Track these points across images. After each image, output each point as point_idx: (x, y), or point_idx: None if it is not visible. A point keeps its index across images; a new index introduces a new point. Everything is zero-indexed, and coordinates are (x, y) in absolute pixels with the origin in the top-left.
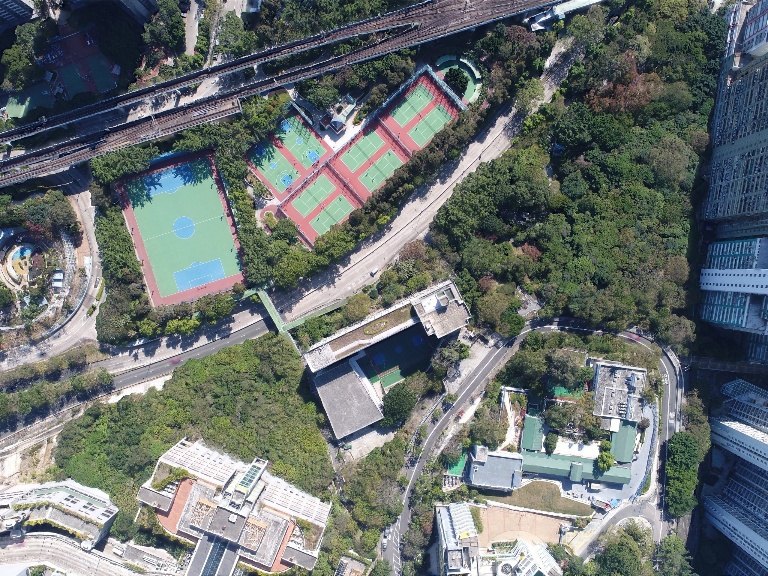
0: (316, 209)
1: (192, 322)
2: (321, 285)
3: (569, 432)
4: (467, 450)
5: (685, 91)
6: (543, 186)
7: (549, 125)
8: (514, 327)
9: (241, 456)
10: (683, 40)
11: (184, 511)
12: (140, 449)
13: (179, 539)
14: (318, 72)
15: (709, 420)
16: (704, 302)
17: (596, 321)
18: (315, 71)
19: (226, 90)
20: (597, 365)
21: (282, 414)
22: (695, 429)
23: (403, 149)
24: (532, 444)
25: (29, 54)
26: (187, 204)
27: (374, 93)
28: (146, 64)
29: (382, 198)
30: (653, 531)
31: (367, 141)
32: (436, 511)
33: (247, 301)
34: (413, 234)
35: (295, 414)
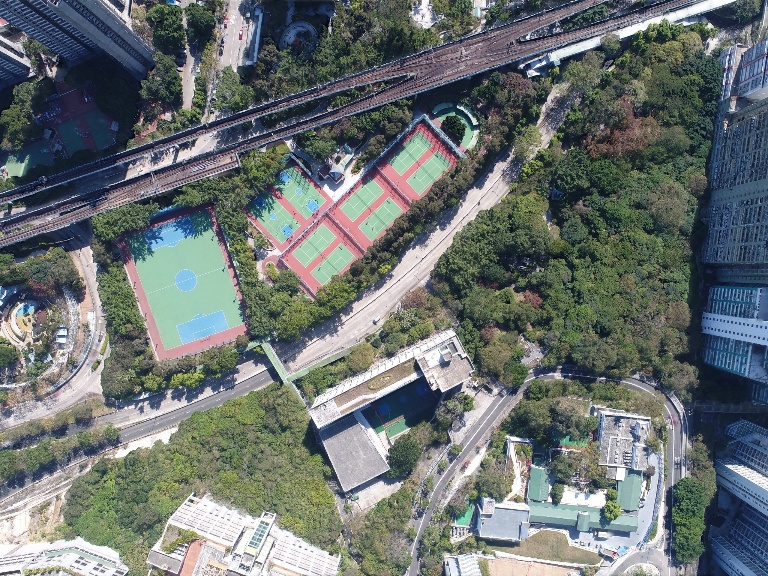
0: (317, 259)
1: (197, 376)
2: (324, 334)
3: (575, 481)
4: (474, 501)
5: (682, 135)
6: (543, 234)
7: (547, 171)
8: (517, 377)
9: (249, 511)
10: (679, 84)
11: (194, 573)
12: (148, 506)
13: None
14: (316, 125)
15: (714, 463)
16: (706, 345)
17: (599, 371)
18: (312, 124)
19: (224, 143)
20: (601, 414)
21: (289, 466)
22: (700, 475)
23: (402, 197)
24: (538, 495)
25: (27, 113)
26: (188, 257)
27: (372, 144)
28: (144, 119)
29: (383, 248)
30: None
31: (366, 190)
32: (445, 562)
33: (251, 352)
34: (414, 281)
35: (302, 466)
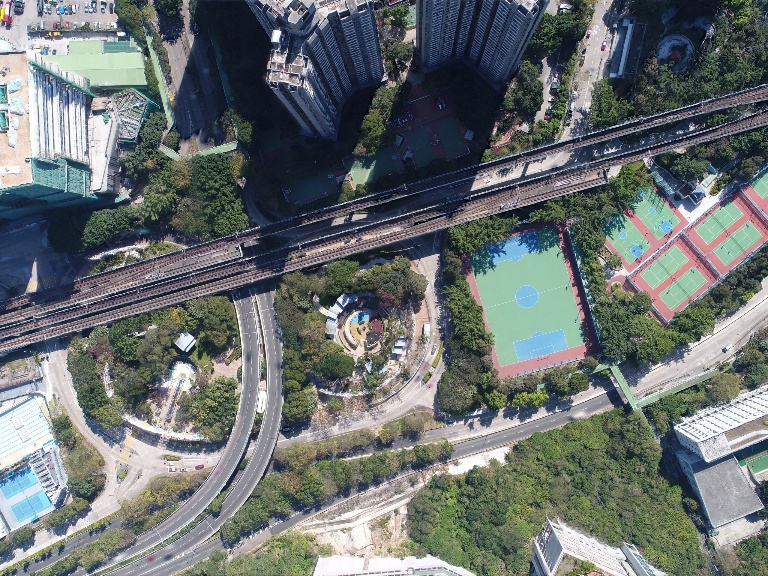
0: (666, 281)
1: (542, 396)
2: (669, 360)
3: None
4: None
5: None
6: None
7: None
8: None
9: (610, 540)
10: None
11: None
12: (507, 529)
13: None
14: (692, 143)
15: None
16: None
17: None
18: (688, 142)
19: (578, 157)
20: None
21: (645, 496)
22: None
23: (763, 221)
24: None
25: (384, 119)
26: (531, 273)
27: (750, 166)
28: (498, 129)
29: (751, 275)
30: None
31: (724, 212)
32: None
33: None
34: None
35: (661, 497)
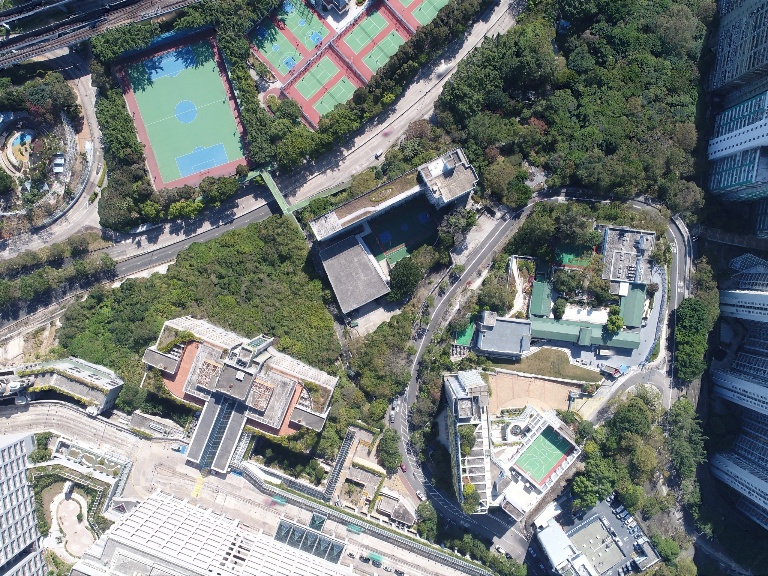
0: (319, 92)
1: (195, 204)
2: (325, 168)
3: (577, 299)
4: (475, 320)
5: None
6: (549, 57)
7: None
8: (521, 196)
9: (247, 332)
10: None
11: (190, 373)
12: (145, 325)
13: (186, 403)
14: None
15: None
16: (712, 173)
17: (604, 184)
18: None
19: None
20: (605, 229)
21: (287, 292)
22: (704, 295)
23: (407, 29)
24: (540, 309)
25: None
26: (189, 88)
27: None
28: None
29: (386, 75)
30: (662, 398)
31: (370, 22)
32: (444, 381)
33: (251, 186)
34: (418, 116)
35: (301, 291)
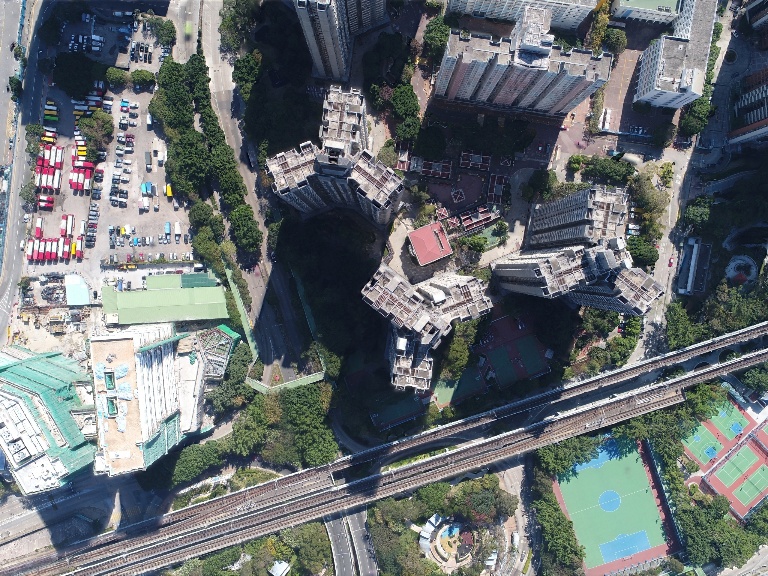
0: (739, 479)
1: None
2: None
3: None
4: None
5: None
6: None
7: None
8: None
9: None
10: None
11: None
12: None
13: None
14: (762, 360)
15: None
16: None
17: None
18: (758, 358)
19: None
20: None
21: None
22: None
23: None
24: None
25: (468, 344)
26: (613, 478)
27: None
28: (576, 346)
29: None
30: None
31: None
32: None
33: None
34: None
35: None
